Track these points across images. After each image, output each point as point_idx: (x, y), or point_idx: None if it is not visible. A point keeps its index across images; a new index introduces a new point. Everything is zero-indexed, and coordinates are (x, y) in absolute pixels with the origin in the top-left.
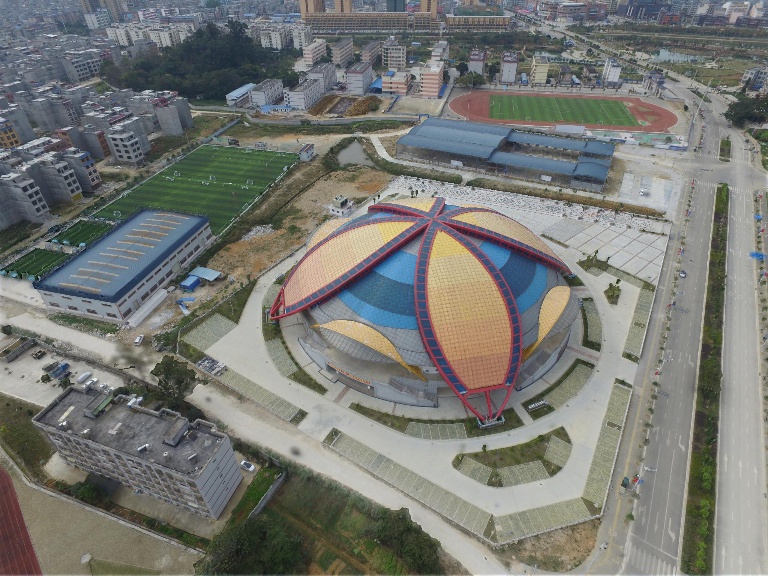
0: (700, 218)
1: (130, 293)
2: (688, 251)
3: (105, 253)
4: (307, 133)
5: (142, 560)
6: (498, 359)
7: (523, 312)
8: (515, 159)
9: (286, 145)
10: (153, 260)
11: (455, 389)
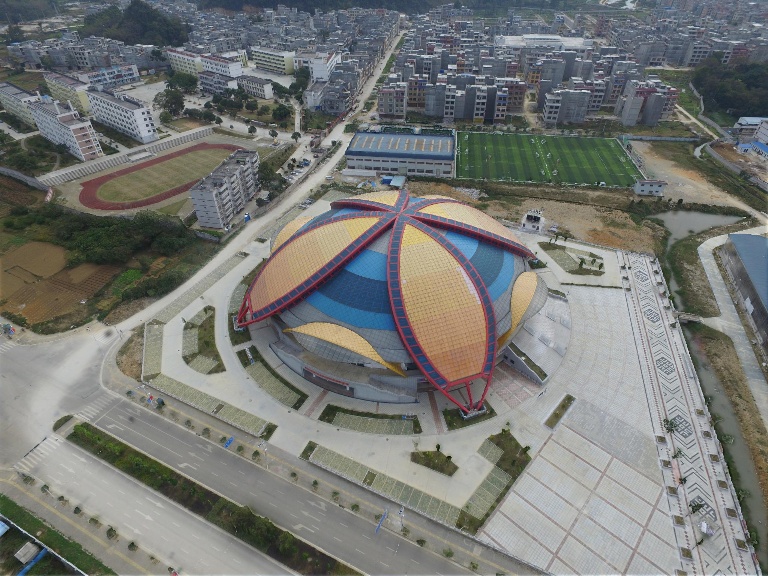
0: None
1: (359, 158)
2: None
3: (393, 139)
4: (716, 181)
5: (184, 209)
6: (265, 298)
7: (311, 304)
8: None
9: (665, 176)
10: (386, 152)
11: None
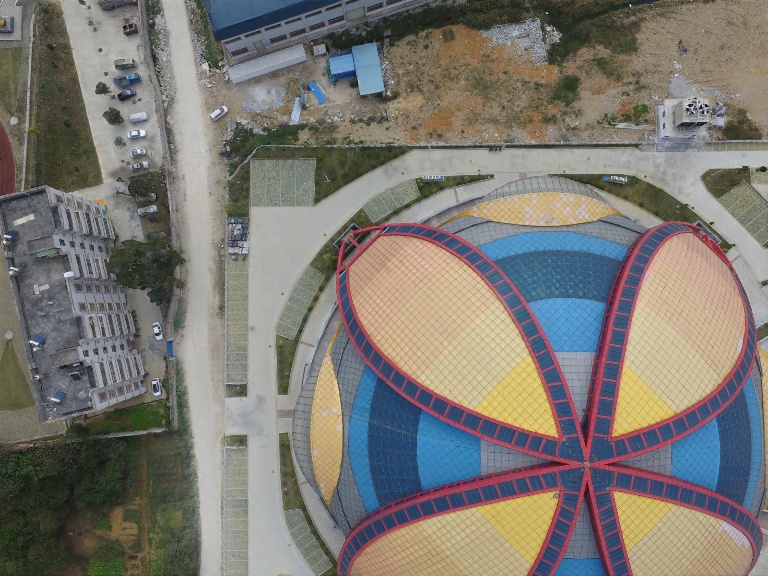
0: None
1: None
2: None
3: None
4: None
5: None
6: None
7: None
8: None
9: None
10: None
11: (339, 569)
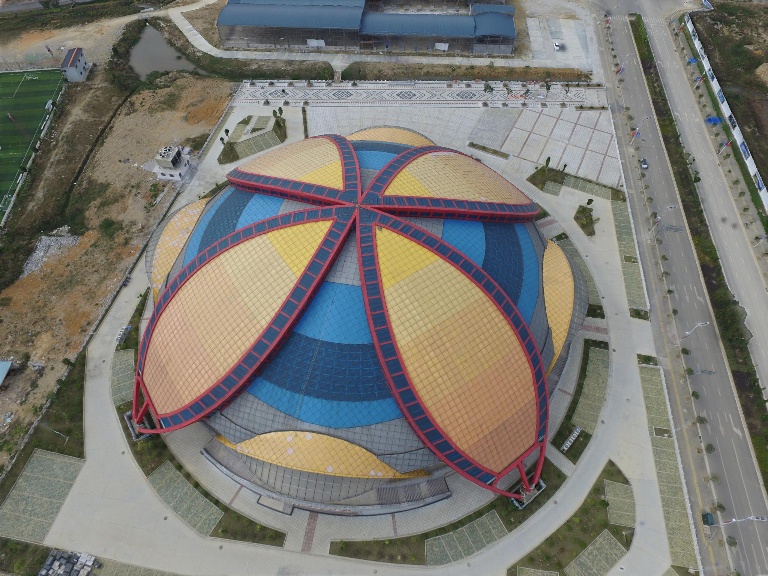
0: (629, 72)
1: None
2: (636, 126)
3: None
4: (60, 24)
5: None
6: (524, 415)
7: (530, 322)
8: (395, 24)
9: (32, 55)
10: None
11: (480, 482)
